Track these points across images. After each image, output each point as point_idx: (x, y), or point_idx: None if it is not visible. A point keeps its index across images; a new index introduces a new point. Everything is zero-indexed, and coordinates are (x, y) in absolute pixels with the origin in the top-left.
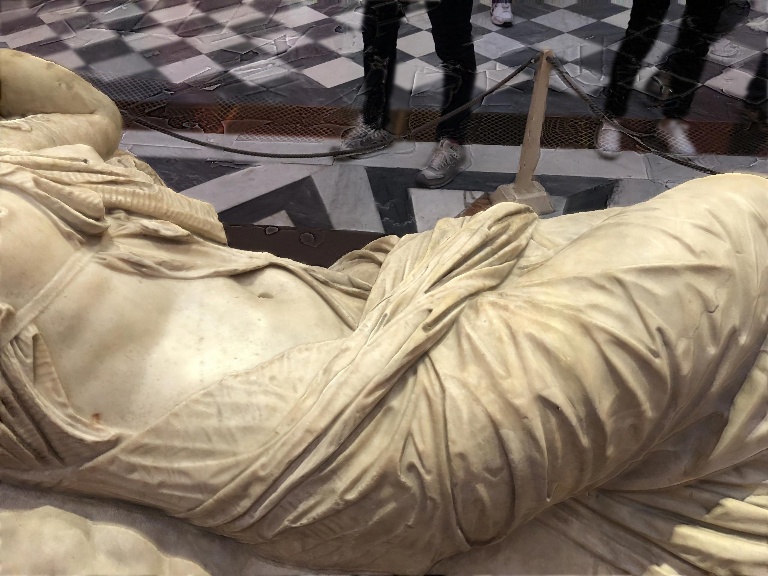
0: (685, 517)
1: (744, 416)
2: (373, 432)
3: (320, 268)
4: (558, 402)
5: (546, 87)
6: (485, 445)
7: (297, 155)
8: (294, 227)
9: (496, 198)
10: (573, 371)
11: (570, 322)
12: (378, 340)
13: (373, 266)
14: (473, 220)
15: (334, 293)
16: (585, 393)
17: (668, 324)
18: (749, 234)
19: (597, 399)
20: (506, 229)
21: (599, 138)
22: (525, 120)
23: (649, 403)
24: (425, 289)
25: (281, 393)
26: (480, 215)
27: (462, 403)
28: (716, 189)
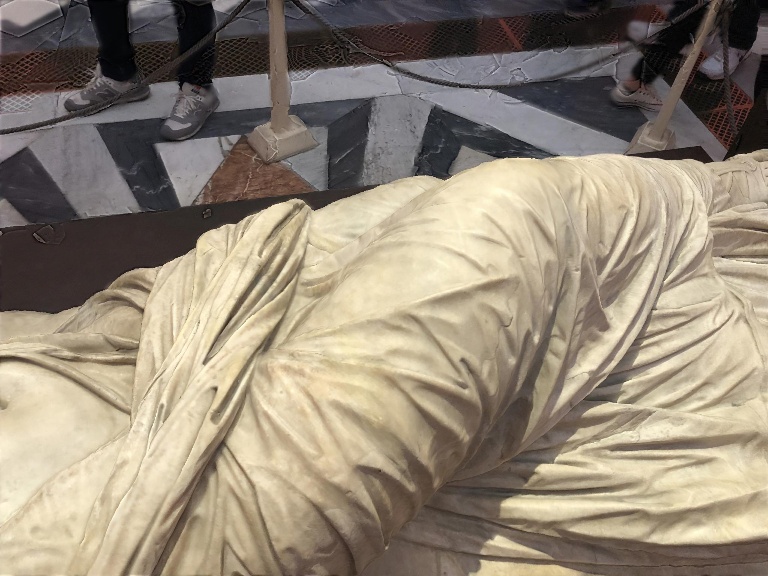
0: (507, 489)
1: (546, 399)
2: (182, 552)
3: (64, 335)
4: (379, 465)
5: (282, 15)
6: (312, 530)
7: (1, 131)
8: (22, 226)
9: (255, 141)
10: (388, 430)
11: (374, 377)
12: (160, 446)
13: (132, 312)
14: (239, 243)
15: (90, 369)
16: (404, 447)
17: (470, 351)
18: (528, 233)
19: (417, 448)
20: (279, 246)
21: (347, 53)
22: (267, 53)
23: (465, 429)
24: (202, 358)
25: (51, 546)
26: (246, 234)
27: (277, 496)
28: (489, 186)
